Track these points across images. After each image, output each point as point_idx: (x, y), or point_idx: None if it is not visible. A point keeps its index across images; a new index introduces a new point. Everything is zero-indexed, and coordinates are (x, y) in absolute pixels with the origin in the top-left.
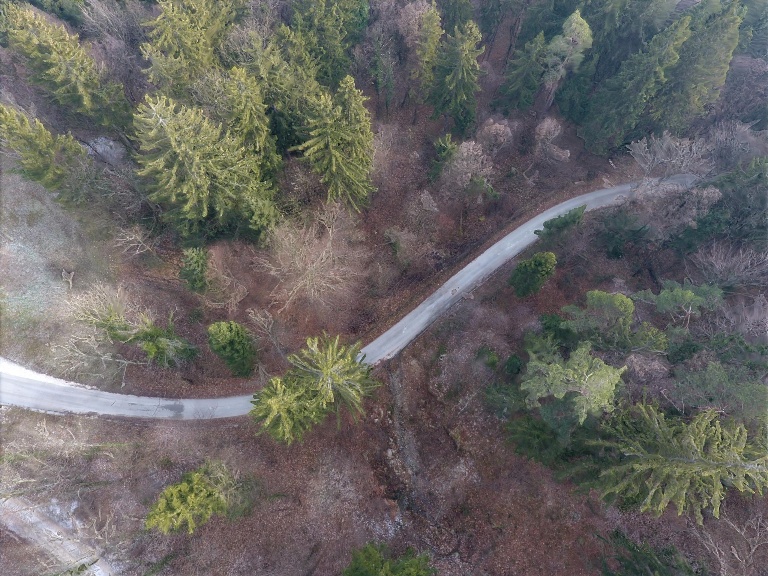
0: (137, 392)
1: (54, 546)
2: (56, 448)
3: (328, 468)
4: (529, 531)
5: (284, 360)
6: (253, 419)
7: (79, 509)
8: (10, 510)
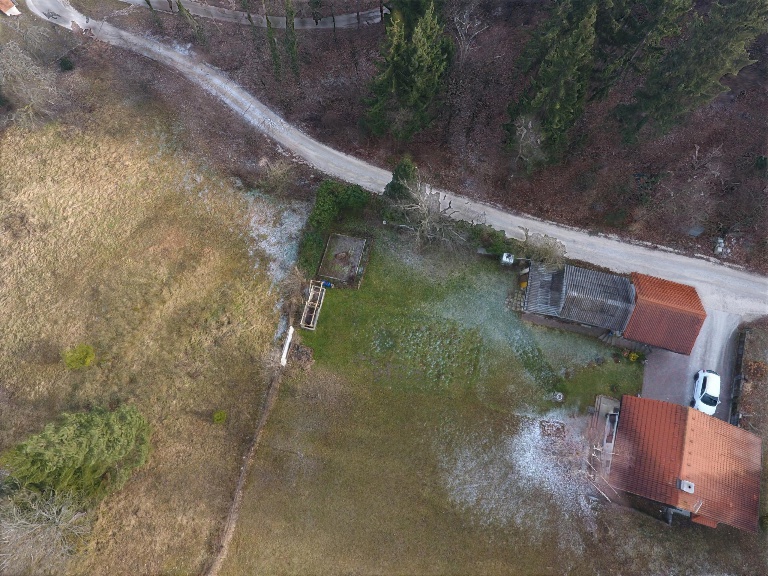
0: (227, 7)
1: (176, 64)
2: (173, 25)
3: (368, 50)
4: (513, 59)
5: (335, 1)
6: (312, 31)
7: (193, 48)
8: (145, 46)
